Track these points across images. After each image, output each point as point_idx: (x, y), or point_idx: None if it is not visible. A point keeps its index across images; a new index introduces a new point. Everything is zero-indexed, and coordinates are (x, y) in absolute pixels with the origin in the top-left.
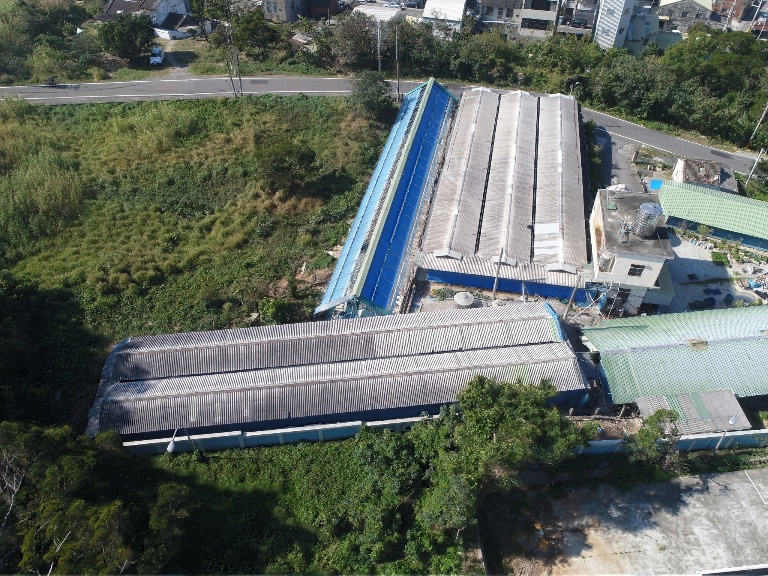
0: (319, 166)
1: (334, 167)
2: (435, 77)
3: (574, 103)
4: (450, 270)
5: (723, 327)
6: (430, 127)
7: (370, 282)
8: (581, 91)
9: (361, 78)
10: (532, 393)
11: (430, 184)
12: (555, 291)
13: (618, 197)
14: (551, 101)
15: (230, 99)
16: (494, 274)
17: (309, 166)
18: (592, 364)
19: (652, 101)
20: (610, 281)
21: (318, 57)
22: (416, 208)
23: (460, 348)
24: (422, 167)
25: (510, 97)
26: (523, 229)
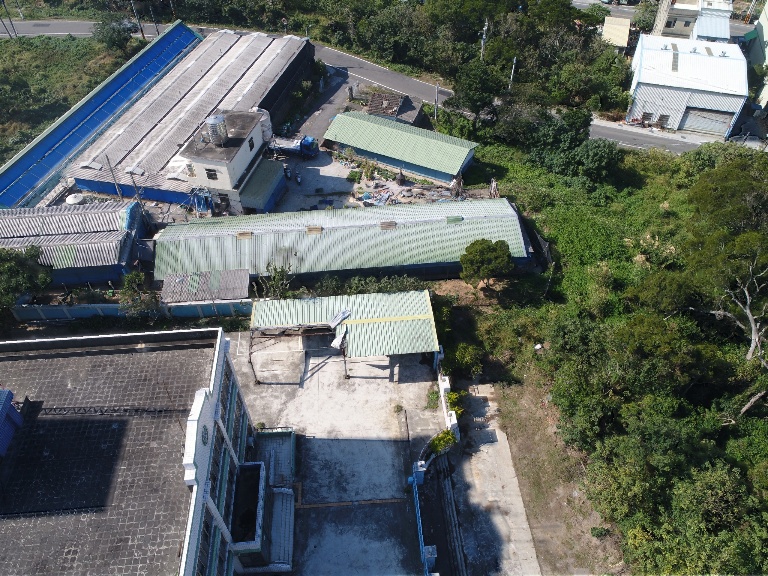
0: (47, 97)
1: (53, 97)
2: (211, 22)
3: (301, 44)
4: (87, 178)
5: (282, 223)
6: (153, 63)
7: (1, 184)
8: (341, 36)
9: (100, 18)
10: (1, 251)
11: (124, 111)
12: (174, 197)
13: (227, 115)
14: (280, 42)
15: (2, 39)
16: (121, 181)
17: (39, 97)
18: (151, 250)
19: (391, 44)
20: (198, 185)
21: (103, 3)
22: (94, 129)
23: (37, 234)
24: (121, 96)
25: (247, 38)
26: (171, 146)
